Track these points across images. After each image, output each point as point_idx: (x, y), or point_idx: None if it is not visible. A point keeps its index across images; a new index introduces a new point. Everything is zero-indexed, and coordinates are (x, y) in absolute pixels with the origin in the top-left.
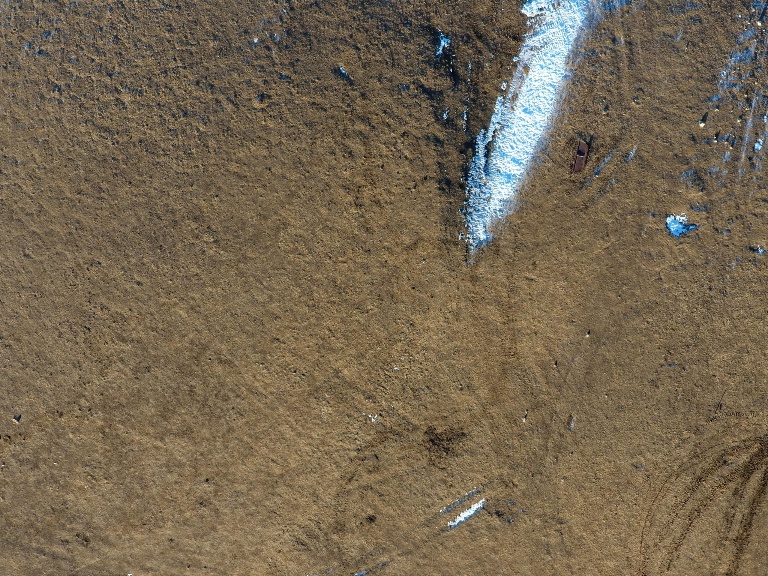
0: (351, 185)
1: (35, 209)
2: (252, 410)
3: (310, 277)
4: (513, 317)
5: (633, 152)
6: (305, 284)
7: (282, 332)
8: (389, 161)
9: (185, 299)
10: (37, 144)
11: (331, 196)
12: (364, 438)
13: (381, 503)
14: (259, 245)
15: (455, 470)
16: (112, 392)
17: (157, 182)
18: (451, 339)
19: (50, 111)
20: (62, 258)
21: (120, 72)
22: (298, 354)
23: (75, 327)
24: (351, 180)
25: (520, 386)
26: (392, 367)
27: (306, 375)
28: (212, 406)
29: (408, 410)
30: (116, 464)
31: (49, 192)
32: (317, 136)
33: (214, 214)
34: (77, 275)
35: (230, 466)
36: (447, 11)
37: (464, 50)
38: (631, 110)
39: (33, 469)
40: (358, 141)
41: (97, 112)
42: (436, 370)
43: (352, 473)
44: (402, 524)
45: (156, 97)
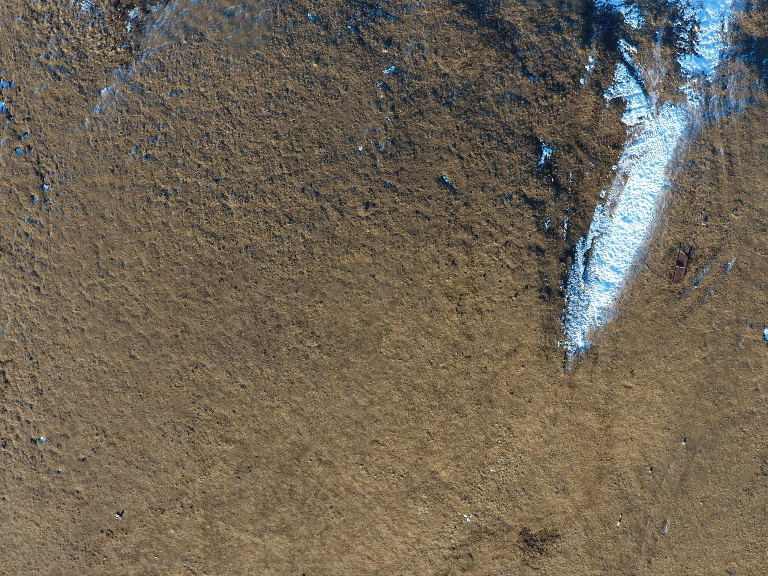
0: (453, 293)
1: (141, 311)
2: (350, 509)
3: (411, 382)
4: (610, 423)
5: (732, 263)
6: (406, 388)
7: (382, 434)
8: (491, 270)
9: (288, 402)
10: (144, 247)
11: (433, 303)
12: (459, 537)
13: None
14: (361, 350)
15: (549, 570)
16: (214, 490)
17: (262, 287)
18: (548, 443)
19: (157, 215)
20: (168, 360)
21: (226, 178)
22: (397, 456)
23: (179, 427)
24: (453, 288)
25: (615, 490)
26: (488, 469)
27: (404, 476)
28: (311, 505)
29: (503, 511)
30: (215, 559)
31: (155, 295)
32: (420, 244)
33: (318, 319)
34: (182, 377)
35: (327, 562)
36: (549, 121)
37: (565, 160)
38: (730, 222)
39: (134, 563)
40: (461, 250)
41: (203, 217)
42: (532, 473)
43: (446, 571)
44: None
45: (262, 203)
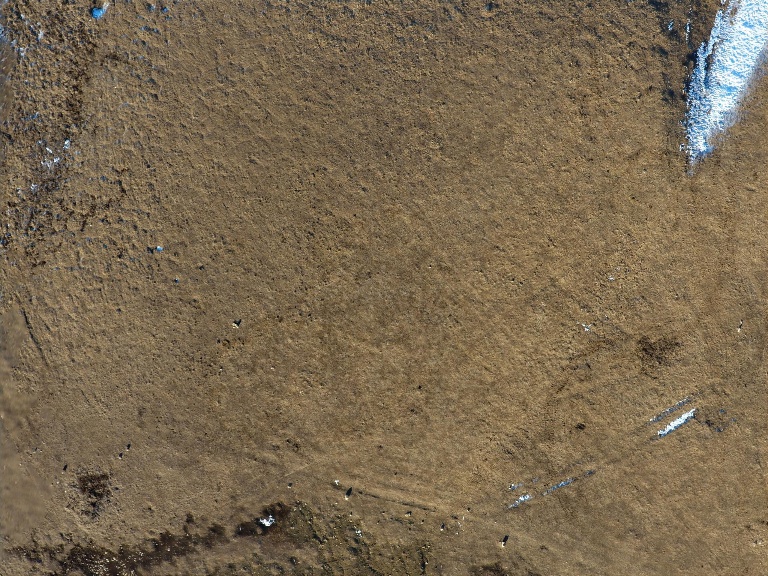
0: (576, 94)
1: (261, 115)
2: (469, 317)
3: (532, 185)
4: (732, 228)
5: None
6: (527, 192)
7: (502, 240)
8: (615, 71)
9: (409, 205)
10: (264, 51)
11: (556, 105)
12: (577, 347)
13: (592, 412)
14: (484, 153)
15: (667, 379)
16: (333, 297)
17: (384, 89)
18: (668, 249)
19: (277, 19)
20: (288, 164)
21: None
22: (517, 262)
23: (299, 232)
24: (577, 89)
25: (736, 296)
26: (608, 277)
27: (524, 283)
28: (430, 313)
29: (622, 320)
30: (332, 370)
31: (276, 98)
32: (544, 45)
33: (440, 121)
34: (303, 181)
35: (443, 373)
36: None
37: None
38: None
39: (250, 373)
40: (584, 51)
41: (325, 20)
42: (652, 280)
43: (563, 382)
44: (612, 433)
45: (384, 5)
